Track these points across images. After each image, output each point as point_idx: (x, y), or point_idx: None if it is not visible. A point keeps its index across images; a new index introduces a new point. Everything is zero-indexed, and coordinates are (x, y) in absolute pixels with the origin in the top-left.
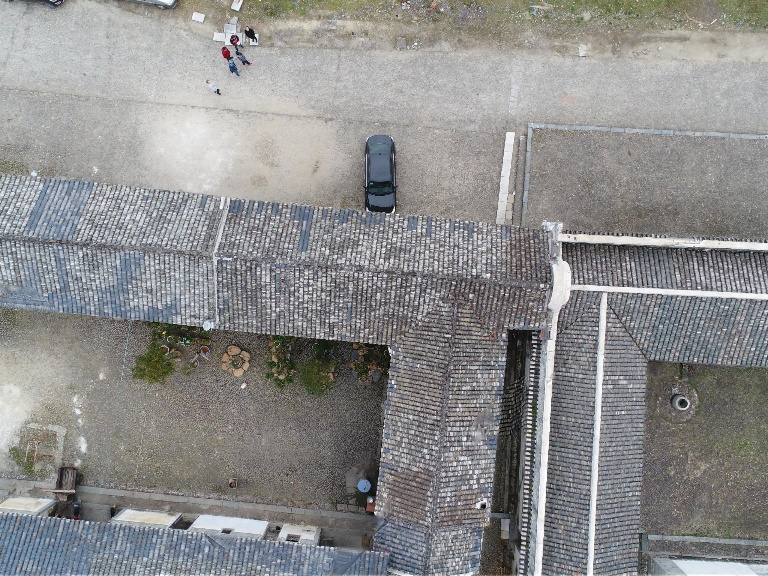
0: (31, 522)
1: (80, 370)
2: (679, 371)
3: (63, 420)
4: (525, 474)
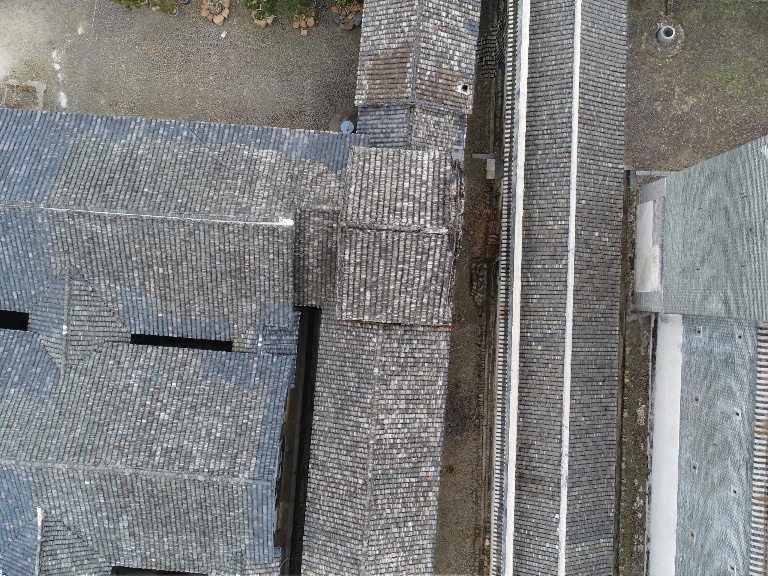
0: (7, 114)
1: (58, 25)
2: (664, 6)
3: (42, 76)
4: (507, 71)
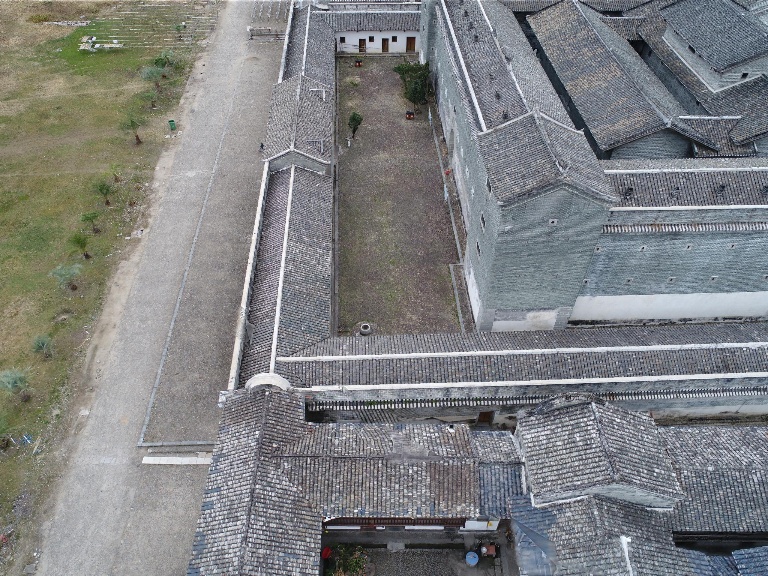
0: None
1: None
2: (343, 333)
3: None
4: None
